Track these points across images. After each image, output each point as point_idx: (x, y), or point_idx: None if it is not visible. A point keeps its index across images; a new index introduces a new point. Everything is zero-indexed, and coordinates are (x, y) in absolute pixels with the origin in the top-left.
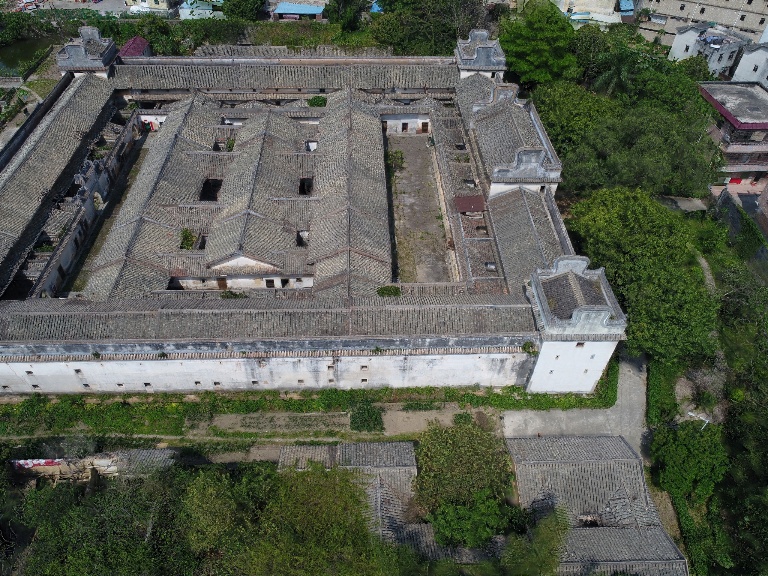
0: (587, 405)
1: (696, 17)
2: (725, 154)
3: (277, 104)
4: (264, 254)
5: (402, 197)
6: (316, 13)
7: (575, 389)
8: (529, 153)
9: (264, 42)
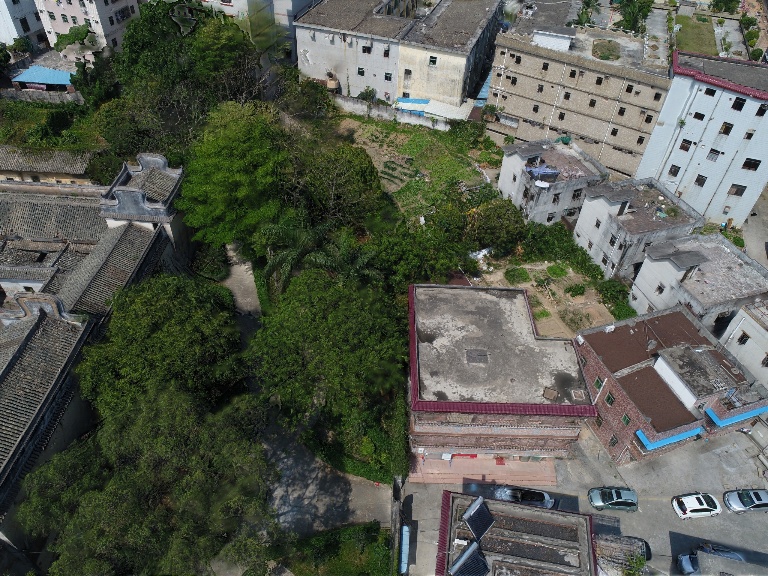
0: None
1: (554, 124)
2: (412, 435)
3: None
4: None
5: None
6: (66, 84)
7: None
8: None
9: None
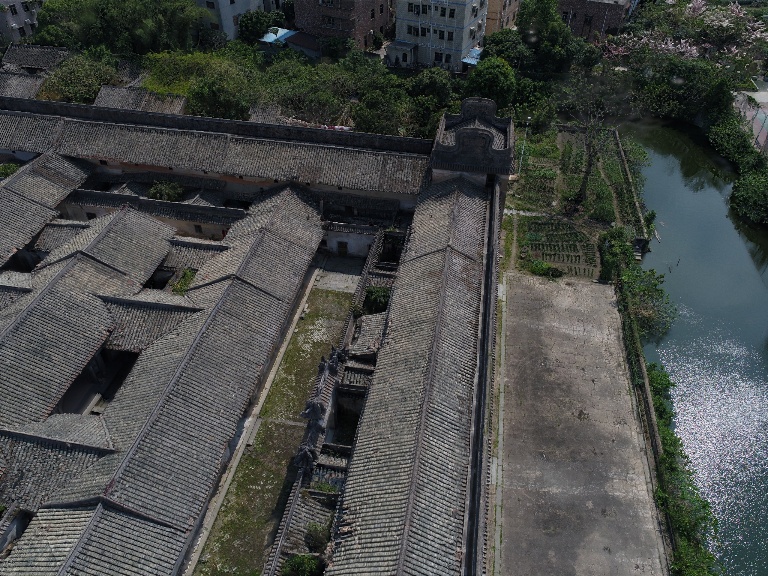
0: None
1: None
2: None
3: None
4: (100, 220)
5: None
6: None
7: None
8: None
9: None
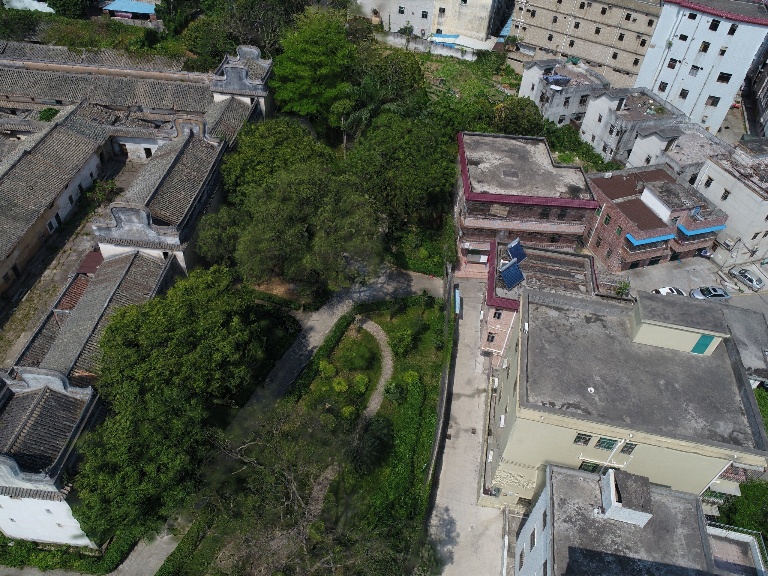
0: (73, 567)
1: (565, 51)
2: (462, 228)
3: (13, 113)
4: None
5: (81, 240)
6: (149, 13)
7: (70, 541)
8: (125, 211)
9: (53, 40)
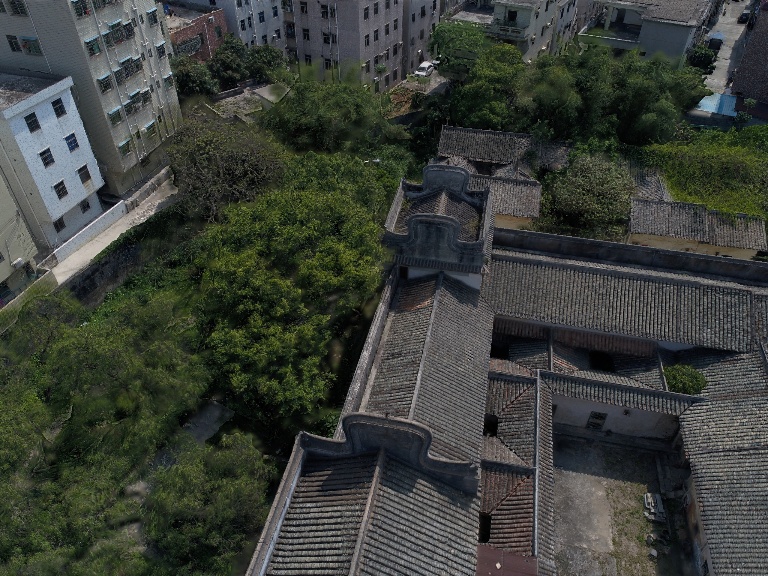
0: None
1: None
2: None
3: None
4: None
5: None
6: None
7: None
8: None
9: None
